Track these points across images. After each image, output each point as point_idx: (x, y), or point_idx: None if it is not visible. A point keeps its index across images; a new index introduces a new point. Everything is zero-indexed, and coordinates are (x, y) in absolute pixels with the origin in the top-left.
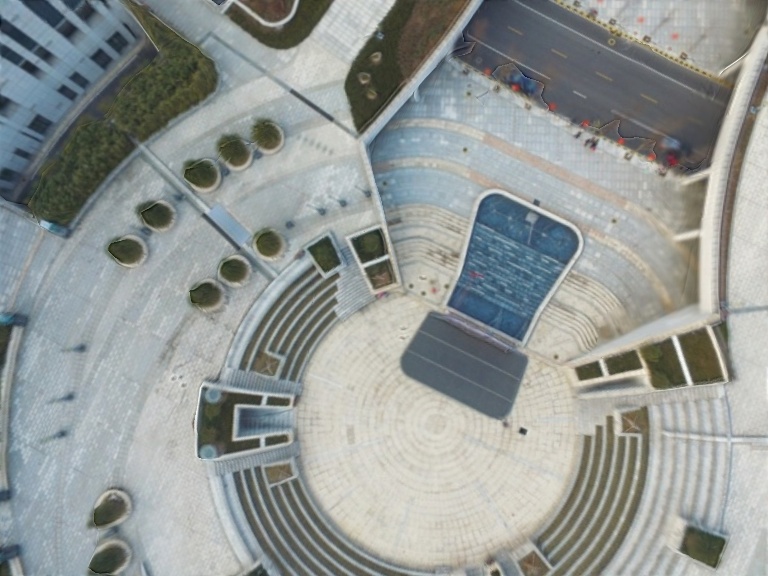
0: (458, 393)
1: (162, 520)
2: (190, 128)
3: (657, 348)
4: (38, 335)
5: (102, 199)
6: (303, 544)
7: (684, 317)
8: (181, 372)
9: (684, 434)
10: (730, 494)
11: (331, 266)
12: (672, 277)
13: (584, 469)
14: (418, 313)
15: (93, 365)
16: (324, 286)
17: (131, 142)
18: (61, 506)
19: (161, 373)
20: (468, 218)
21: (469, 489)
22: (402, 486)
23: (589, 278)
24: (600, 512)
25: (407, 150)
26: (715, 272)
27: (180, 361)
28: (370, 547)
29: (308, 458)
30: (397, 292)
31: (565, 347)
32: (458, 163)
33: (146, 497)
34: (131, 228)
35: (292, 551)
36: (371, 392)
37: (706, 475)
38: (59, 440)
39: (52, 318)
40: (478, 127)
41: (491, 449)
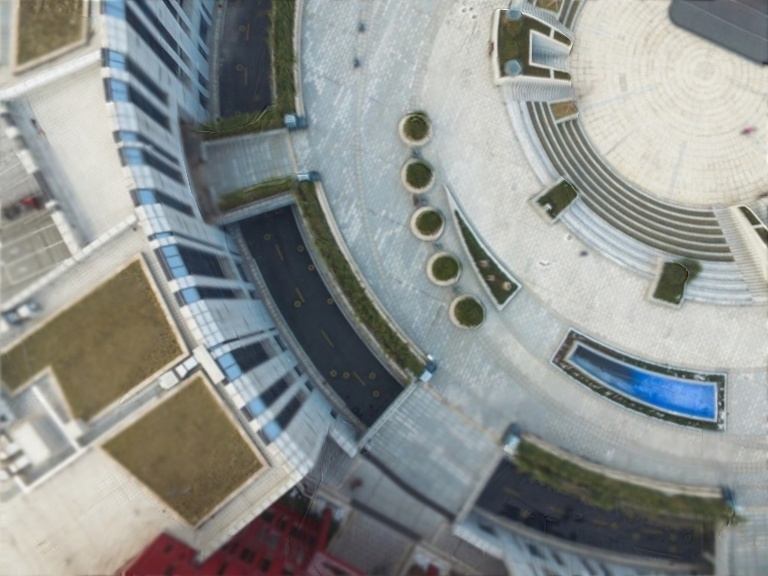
0: (726, 39)
1: (461, 145)
2: None
3: None
4: None
5: None
6: (591, 177)
7: None
8: (471, 4)
9: None
10: None
11: None
12: None
13: None
14: None
15: None
16: None
17: None
18: (359, 134)
19: (451, 5)
20: None
21: (739, 132)
22: (675, 130)
23: None
24: None
25: None
26: None
27: None
28: (647, 188)
29: (583, 105)
30: None
31: None
32: None
33: (444, 123)
34: None
35: (583, 181)
36: (641, 41)
37: None
38: (355, 69)
39: None
40: None
41: (758, 93)
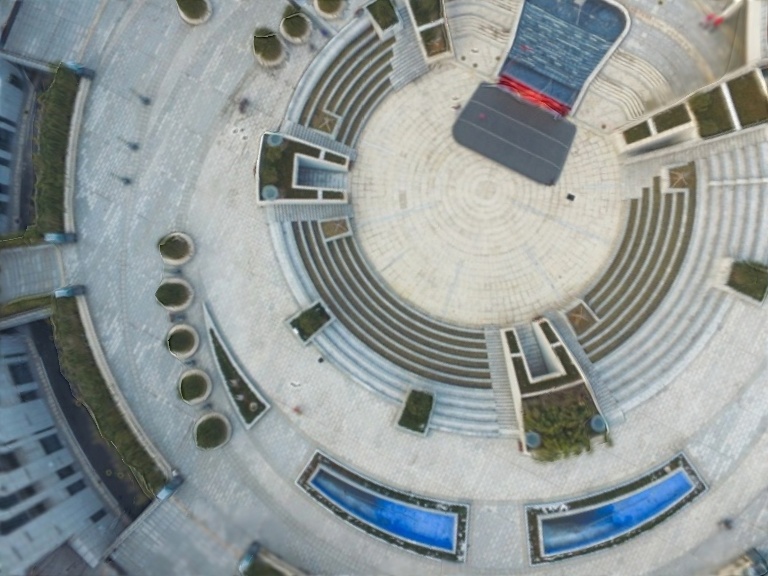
0: (508, 160)
1: (223, 264)
2: None
3: (706, 97)
4: (104, 89)
5: None
6: (357, 296)
7: (732, 72)
8: (242, 125)
9: (731, 180)
10: None
11: (389, 23)
12: (717, 56)
13: (630, 230)
14: (470, 84)
15: (157, 118)
16: (380, 50)
17: None
18: (125, 250)
19: (223, 126)
20: None
21: (517, 252)
22: (452, 249)
23: (636, 56)
24: (646, 266)
25: None
26: (764, 21)
27: (241, 115)
28: (421, 306)
29: (361, 221)
30: (450, 64)
31: (612, 117)
32: None
33: (208, 242)
34: None
35: (347, 300)
36: (423, 159)
37: (753, 217)
38: (124, 187)
39: (118, 73)
40: None
41: (539, 214)
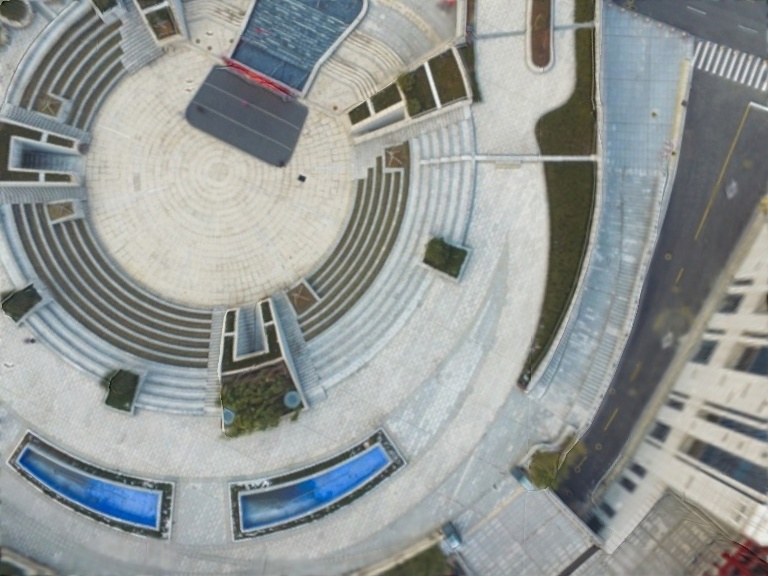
0: (240, 141)
1: None
2: None
3: (411, 76)
4: None
5: None
6: (82, 277)
7: None
8: None
9: (436, 159)
10: (474, 210)
11: (107, 5)
12: None
13: (356, 211)
14: (204, 67)
15: None
16: (107, 33)
17: None
18: None
19: None
20: None
21: (249, 233)
22: (185, 231)
23: (373, 38)
24: (366, 246)
25: None
26: None
27: None
28: (153, 288)
29: (95, 204)
30: (184, 47)
31: (344, 99)
32: None
33: None
34: None
35: (70, 282)
36: (157, 142)
37: (454, 195)
38: None
39: None
40: None
41: (271, 195)
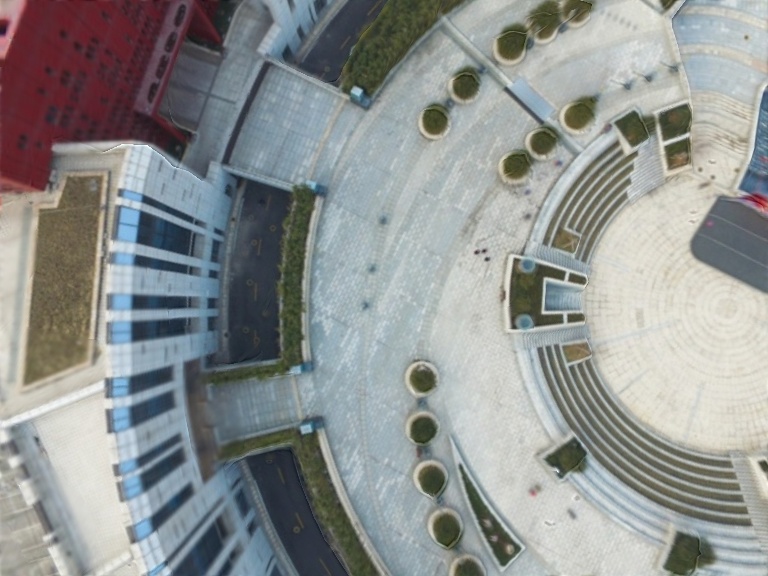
0: (750, 277)
1: (468, 393)
2: (491, 1)
3: None
4: (338, 207)
5: (401, 71)
6: (602, 423)
7: None
8: (484, 246)
9: None
10: None
11: (640, 140)
12: None
13: None
14: (708, 197)
15: (394, 237)
16: (622, 164)
17: (437, 12)
18: (365, 378)
19: (464, 246)
20: (752, 105)
21: (761, 374)
22: (693, 370)
23: None
24: None
25: (688, 37)
26: None
27: (483, 235)
28: (661, 431)
29: (597, 341)
30: (686, 175)
31: None
32: (740, 50)
33: (452, 370)
34: (433, 100)
35: (594, 429)
36: (660, 275)
37: None
38: (363, 311)
39: (352, 190)
40: (759, 15)
41: None
